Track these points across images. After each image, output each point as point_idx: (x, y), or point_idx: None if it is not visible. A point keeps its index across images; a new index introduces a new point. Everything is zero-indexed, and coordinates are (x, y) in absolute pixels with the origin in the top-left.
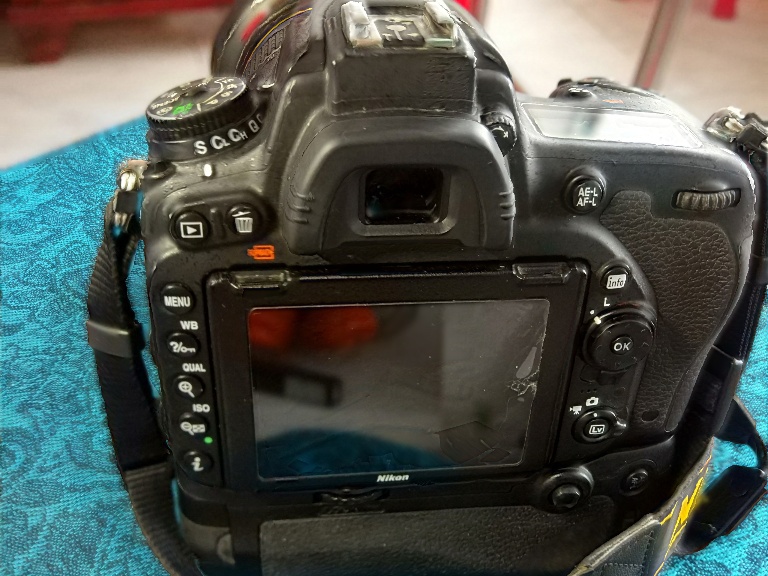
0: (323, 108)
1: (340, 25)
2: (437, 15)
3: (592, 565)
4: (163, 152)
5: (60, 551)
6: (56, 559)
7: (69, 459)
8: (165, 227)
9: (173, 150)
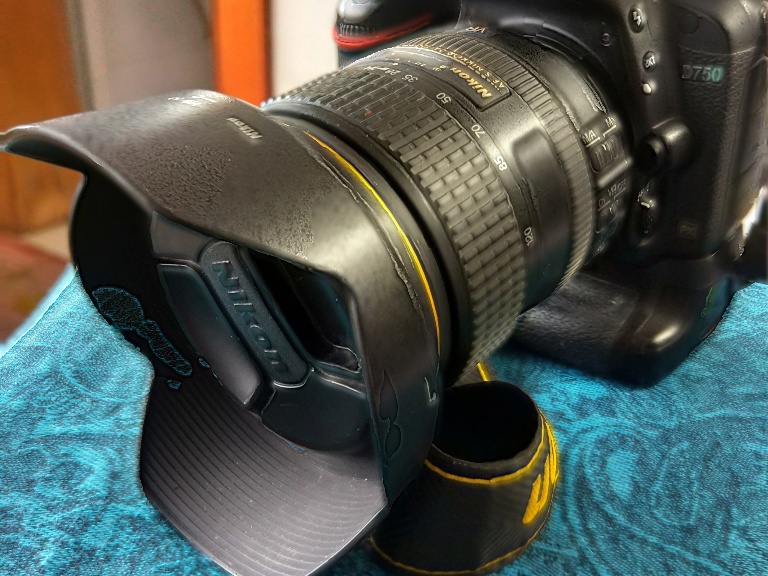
0: None
1: None
2: None
3: None
4: None
5: None
6: None
7: None
8: None
9: None
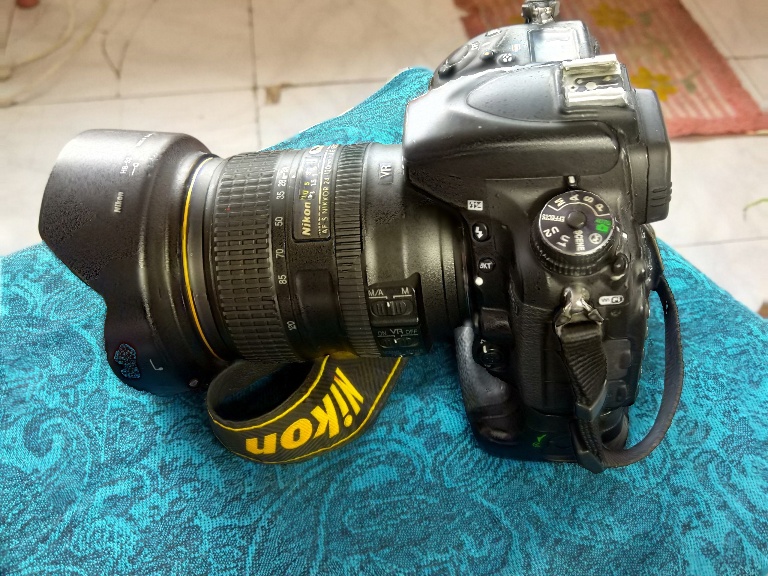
0: (627, 148)
1: (598, 107)
2: (599, 62)
3: (652, 230)
4: None
5: (582, 572)
6: (588, 575)
7: (498, 574)
8: (635, 284)
9: (612, 249)
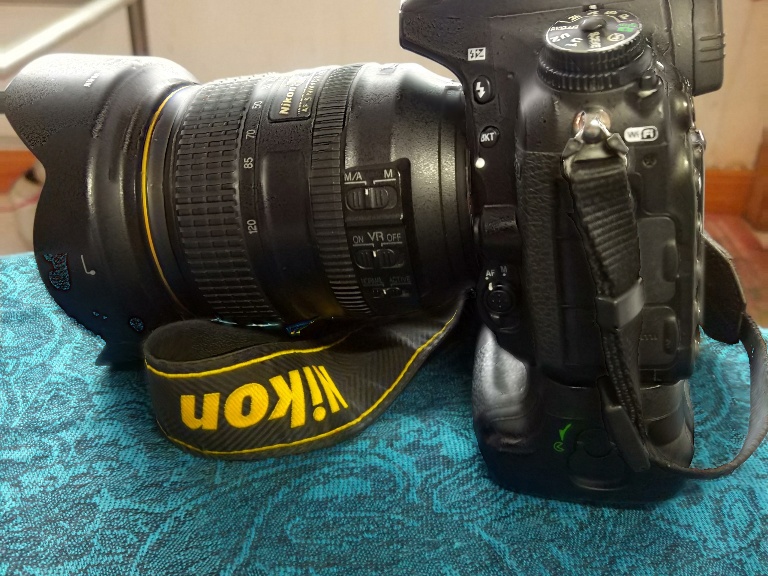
0: None
1: None
2: None
3: None
4: (634, 71)
5: None
6: None
7: None
8: (675, 123)
9: None
